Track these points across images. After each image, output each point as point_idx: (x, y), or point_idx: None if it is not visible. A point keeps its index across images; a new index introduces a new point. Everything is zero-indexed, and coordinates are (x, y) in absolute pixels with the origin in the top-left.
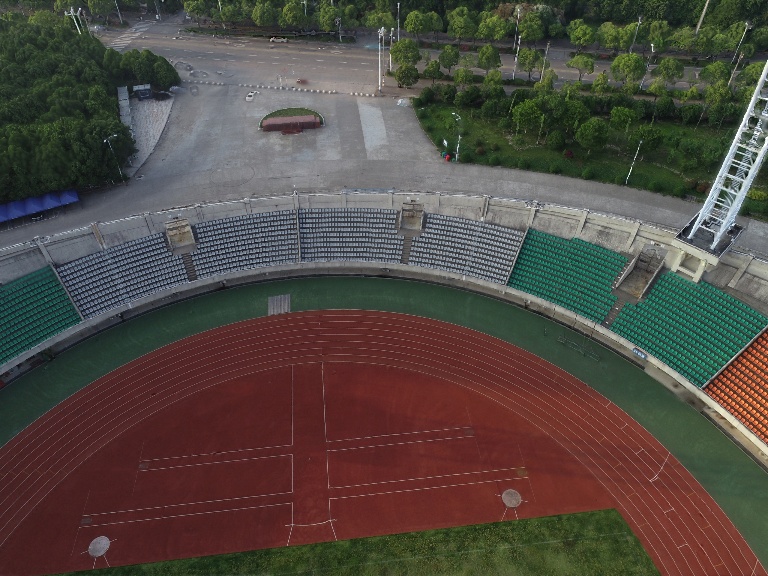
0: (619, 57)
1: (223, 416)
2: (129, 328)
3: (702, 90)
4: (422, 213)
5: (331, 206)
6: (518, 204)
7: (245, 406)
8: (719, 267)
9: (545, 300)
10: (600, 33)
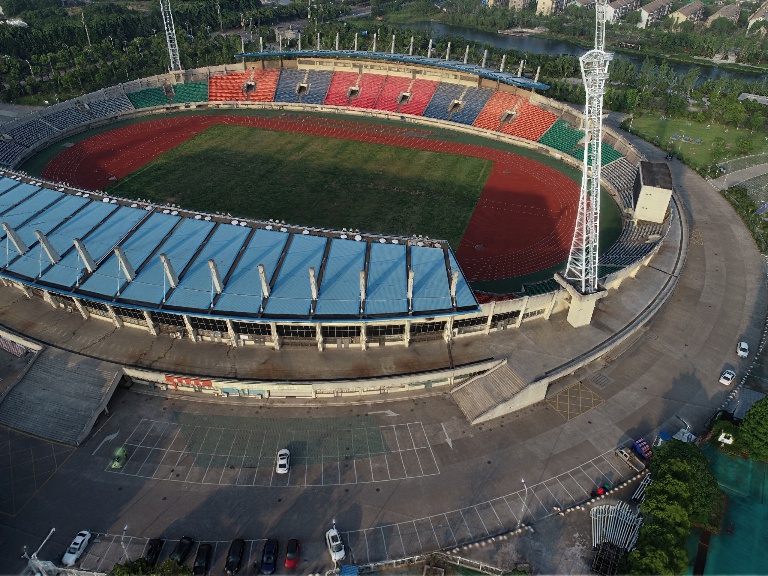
0: (76, 59)
1: (99, 159)
2: (25, 168)
3: (120, 61)
4: (85, 103)
5: (49, 114)
6: (115, 87)
7: (102, 155)
8: (186, 77)
9: (151, 107)
10: (52, 57)
